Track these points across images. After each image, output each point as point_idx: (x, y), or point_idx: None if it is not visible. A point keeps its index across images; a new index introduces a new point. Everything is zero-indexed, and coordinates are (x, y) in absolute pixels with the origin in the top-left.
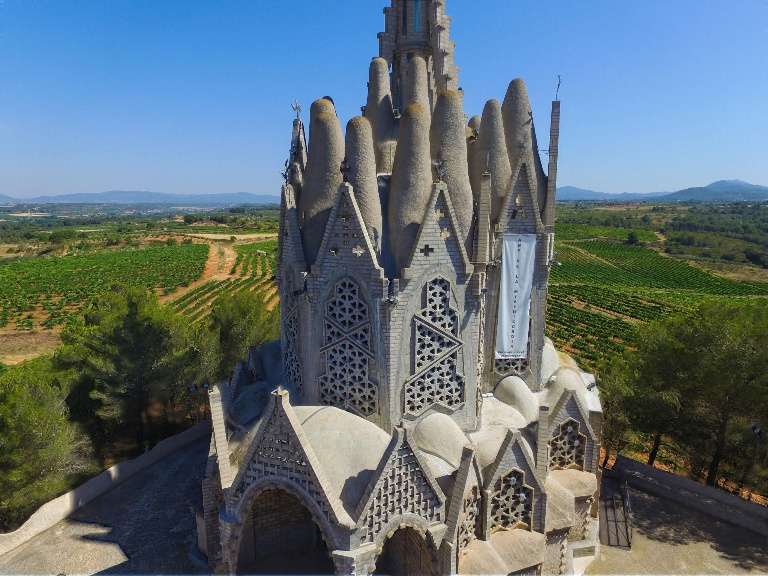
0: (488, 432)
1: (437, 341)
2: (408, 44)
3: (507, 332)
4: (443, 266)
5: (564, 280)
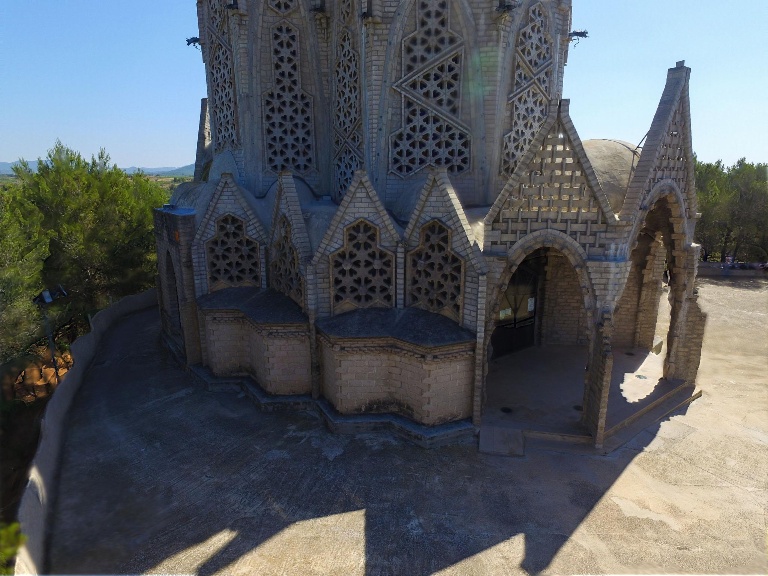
0: None
1: None
2: None
3: None
4: None
5: None
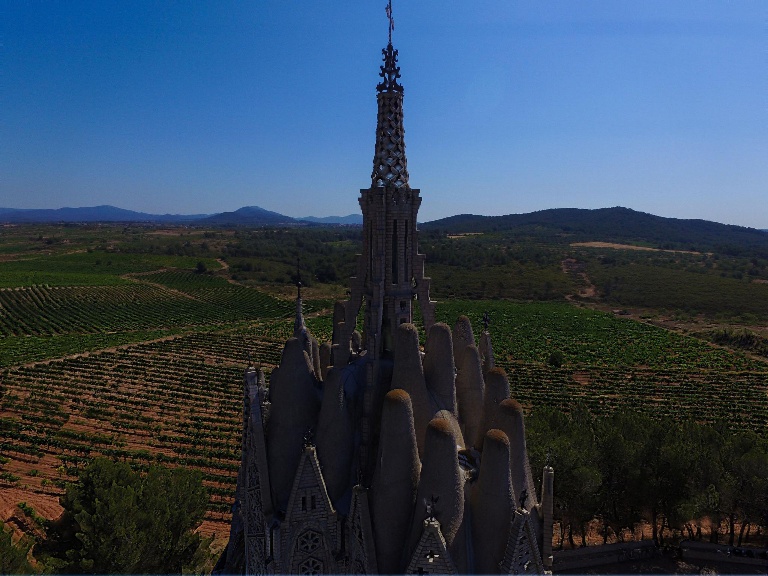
0: None
1: None
2: (400, 293)
3: None
4: None
5: (162, 326)
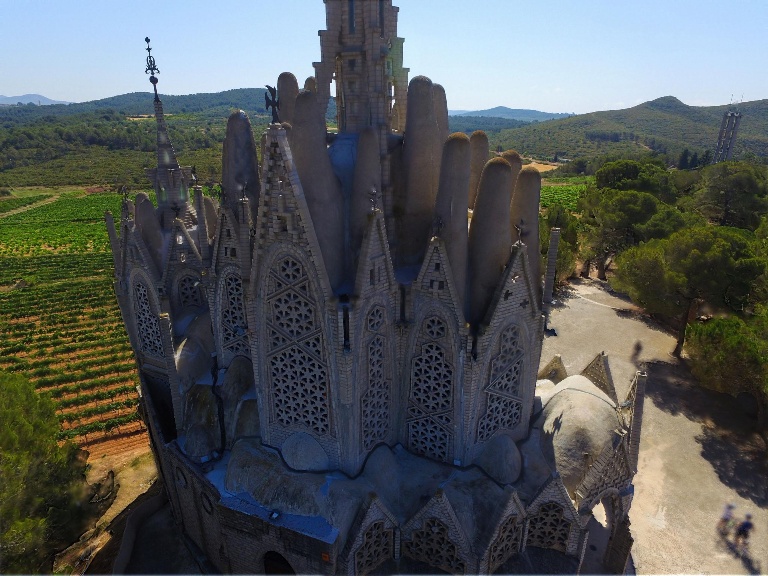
0: None
1: None
2: (387, 50)
3: None
4: None
5: None
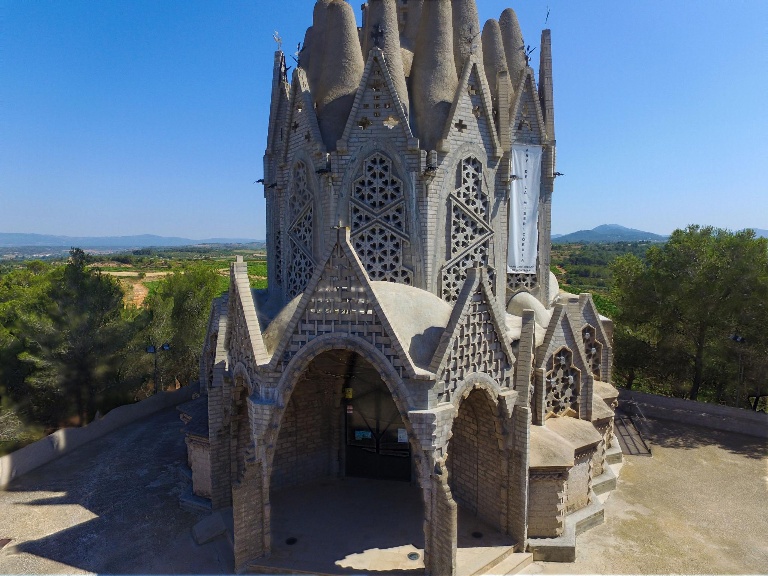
0: (519, 330)
1: (470, 226)
2: None
3: (518, 245)
4: (475, 146)
5: None
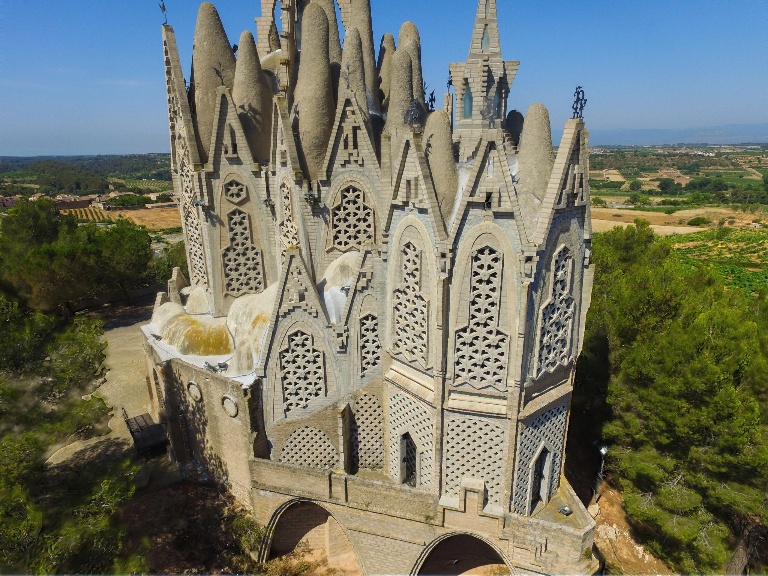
0: None
1: None
2: None
3: None
4: None
5: None
